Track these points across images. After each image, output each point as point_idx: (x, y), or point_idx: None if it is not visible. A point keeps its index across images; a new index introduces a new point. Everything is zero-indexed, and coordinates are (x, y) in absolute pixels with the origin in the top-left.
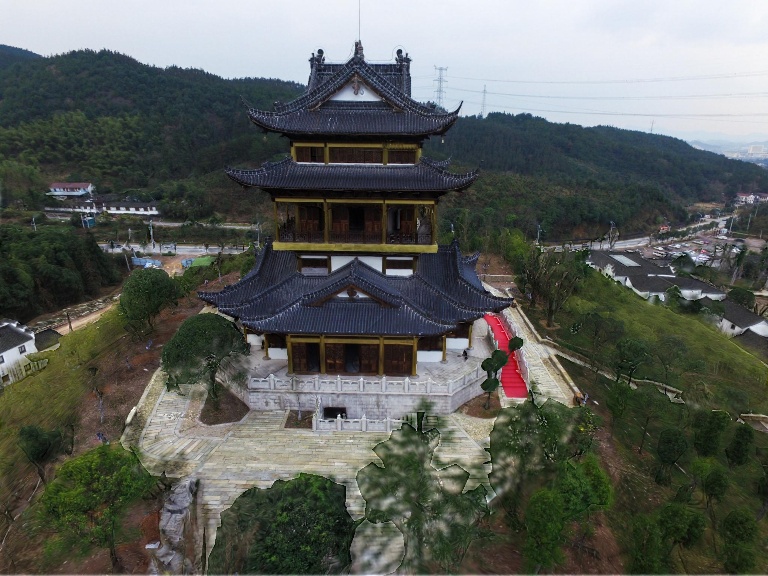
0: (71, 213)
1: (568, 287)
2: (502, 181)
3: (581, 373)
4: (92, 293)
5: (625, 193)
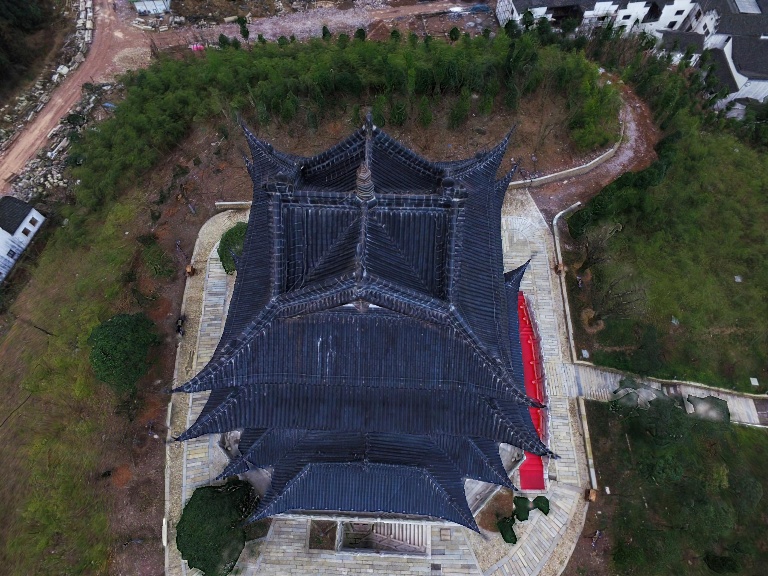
0: None
1: (635, 210)
2: None
3: (605, 429)
4: (21, 59)
5: None
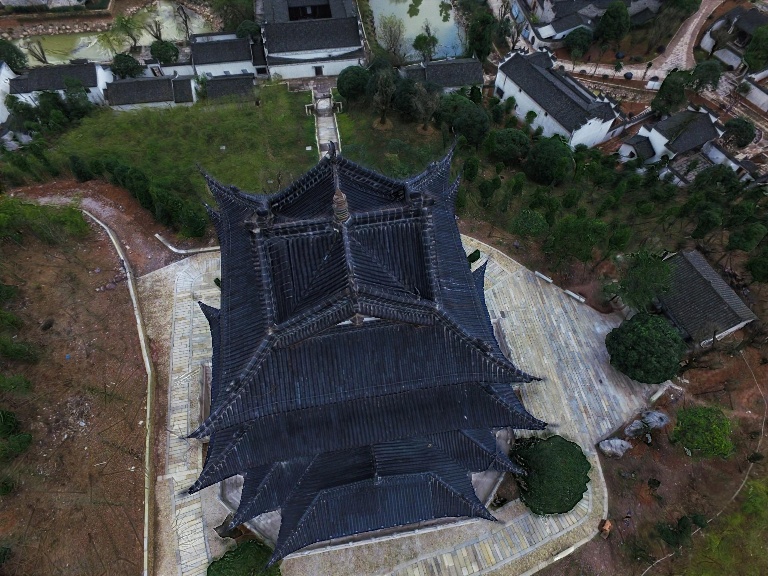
0: None
1: None
2: None
3: None
4: None
5: None
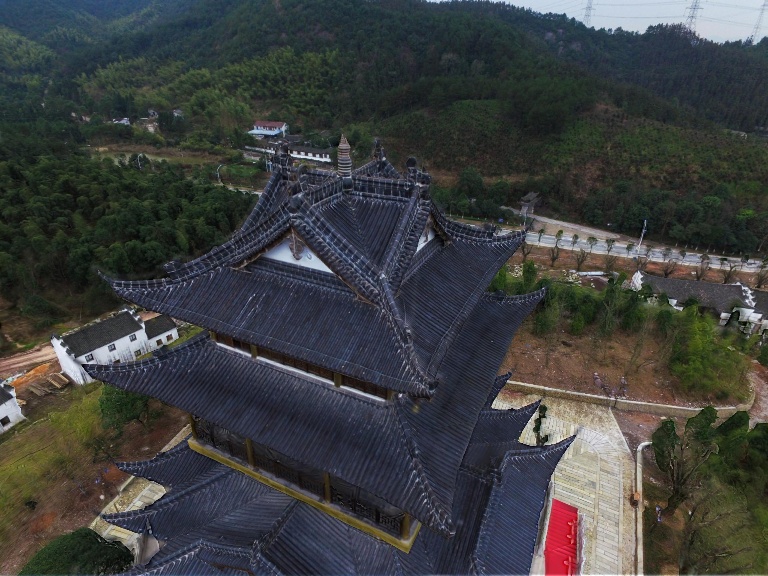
0: (263, 153)
1: (761, 470)
2: (748, 155)
3: None
4: None
5: None
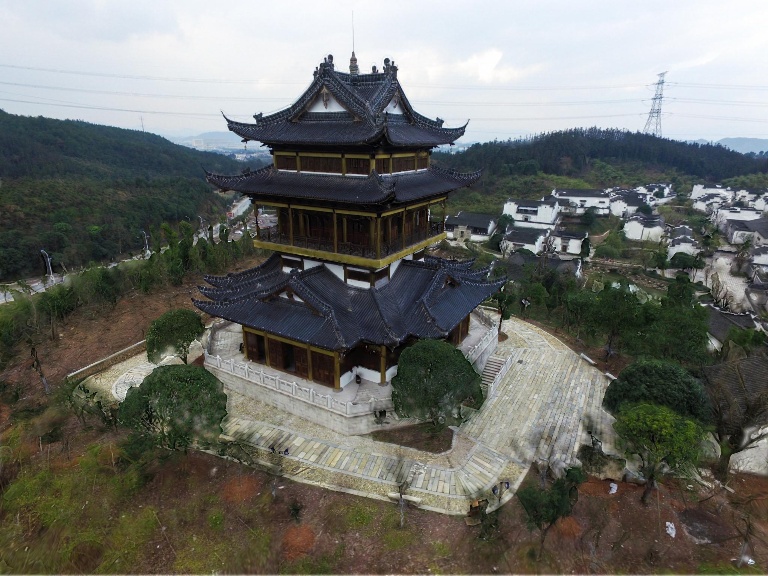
0: None
1: None
2: (46, 189)
3: None
4: None
5: (180, 188)
